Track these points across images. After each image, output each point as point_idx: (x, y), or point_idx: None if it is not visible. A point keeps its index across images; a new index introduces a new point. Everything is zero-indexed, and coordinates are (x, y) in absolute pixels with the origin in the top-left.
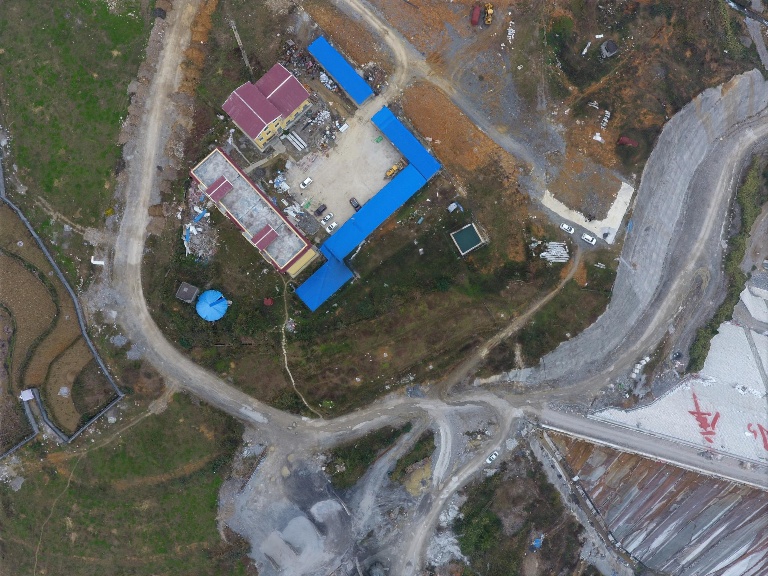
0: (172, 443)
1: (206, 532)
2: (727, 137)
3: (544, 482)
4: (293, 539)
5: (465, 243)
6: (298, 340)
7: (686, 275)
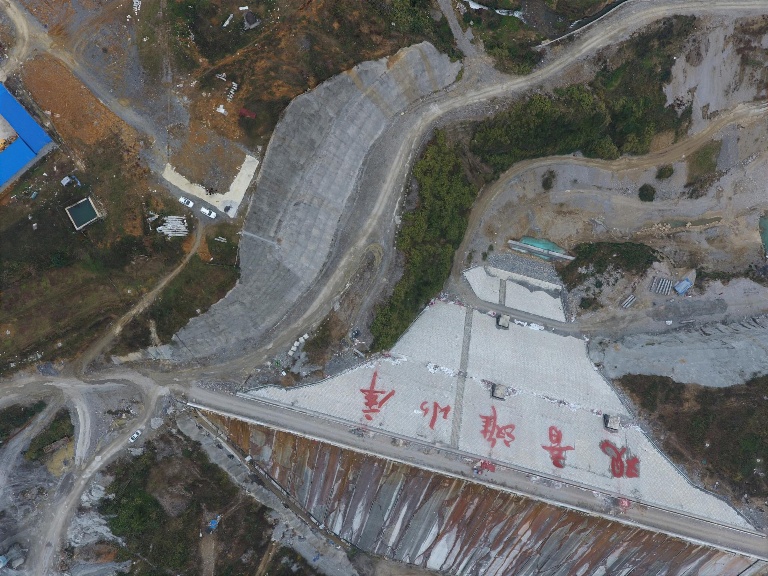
0: None
1: None
2: (408, 112)
3: (205, 462)
4: None
5: (81, 218)
6: None
7: (356, 251)
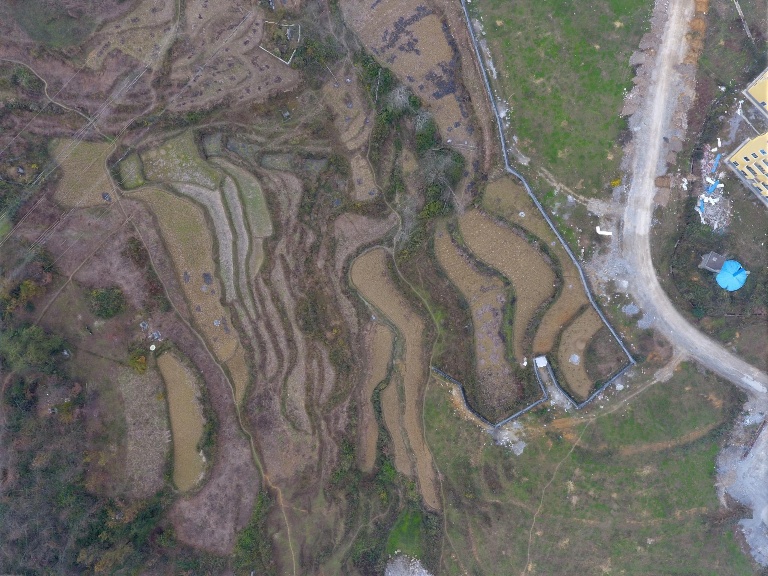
0: (679, 410)
1: (706, 498)
2: None
3: None
4: None
5: None
6: None
7: None
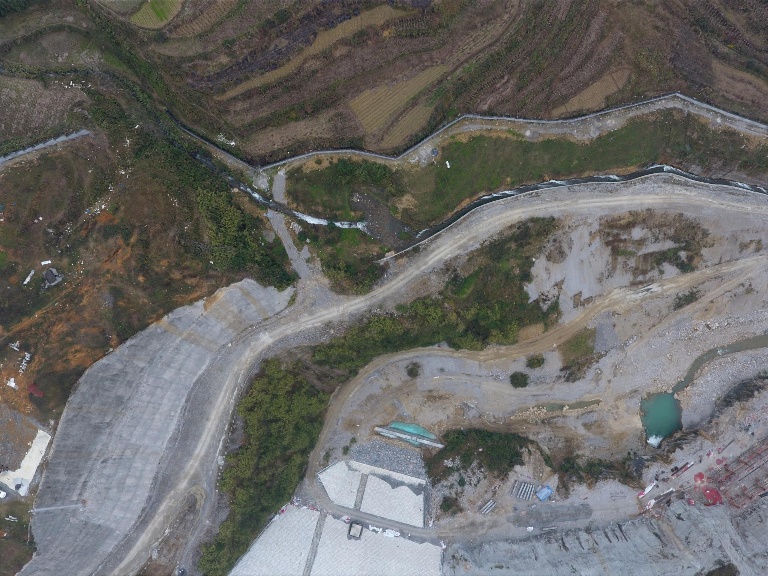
0: None
1: None
2: (235, 343)
3: None
4: None
5: None
6: None
7: (176, 495)
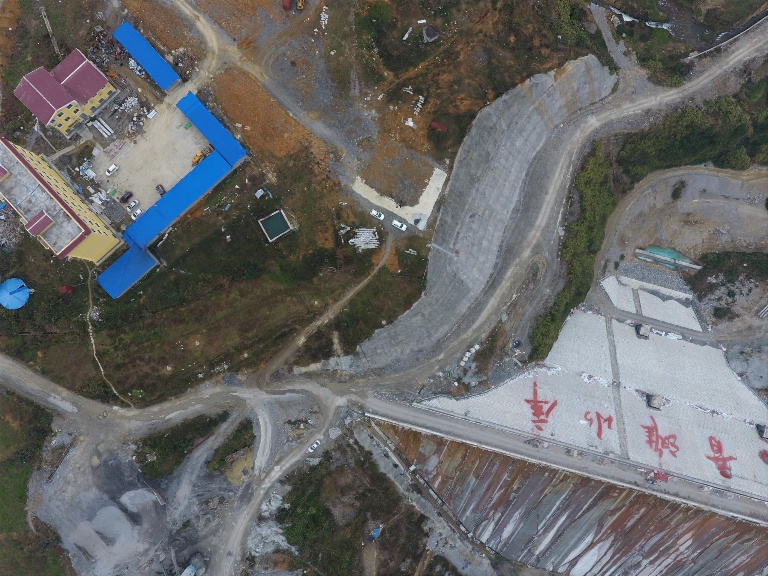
0: None
1: (15, 522)
2: (568, 124)
3: (375, 471)
4: (105, 529)
5: (274, 230)
6: (104, 328)
7: (521, 262)
